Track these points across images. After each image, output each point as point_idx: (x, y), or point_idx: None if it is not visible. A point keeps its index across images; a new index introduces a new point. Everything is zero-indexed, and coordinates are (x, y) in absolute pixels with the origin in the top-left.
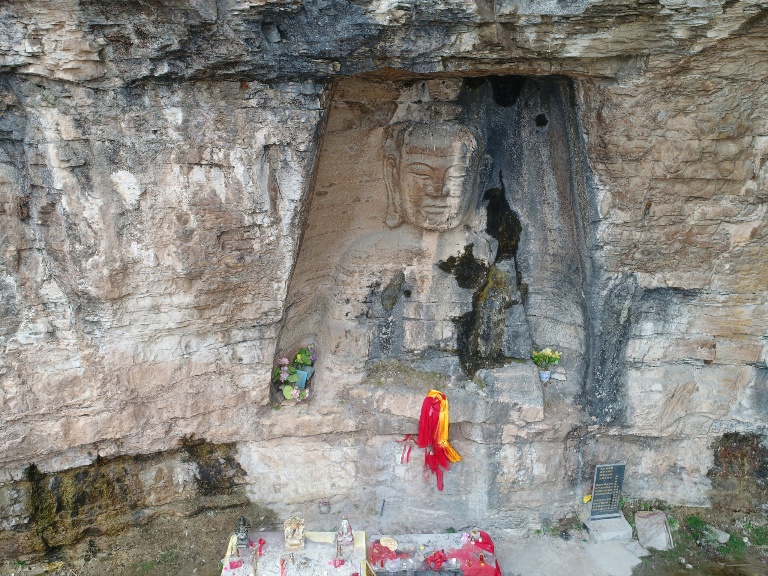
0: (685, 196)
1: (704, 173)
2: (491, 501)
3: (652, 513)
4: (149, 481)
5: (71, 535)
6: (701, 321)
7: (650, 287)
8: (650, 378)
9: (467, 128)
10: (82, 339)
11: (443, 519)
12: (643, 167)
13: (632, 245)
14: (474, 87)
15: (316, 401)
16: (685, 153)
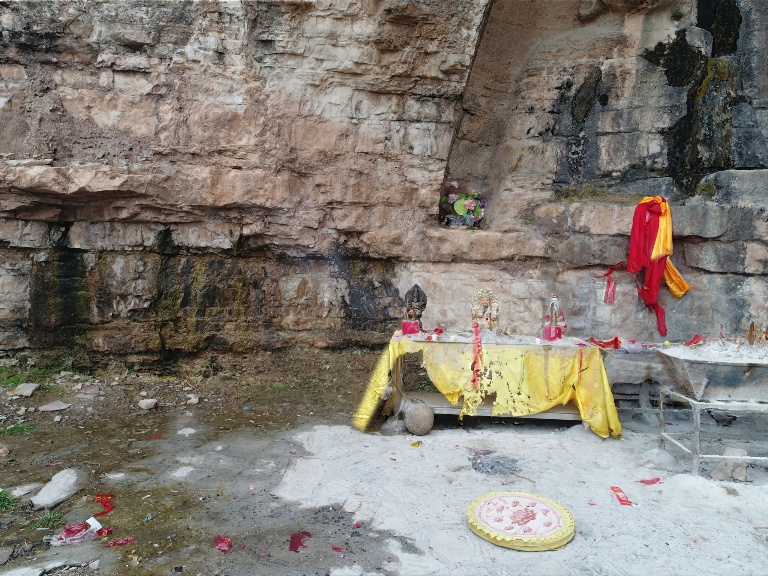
0: None
1: None
2: None
3: None
4: (290, 293)
5: (193, 338)
6: None
7: None
8: None
9: None
10: (250, 68)
11: (670, 375)
12: None
13: None
14: None
15: None
16: None
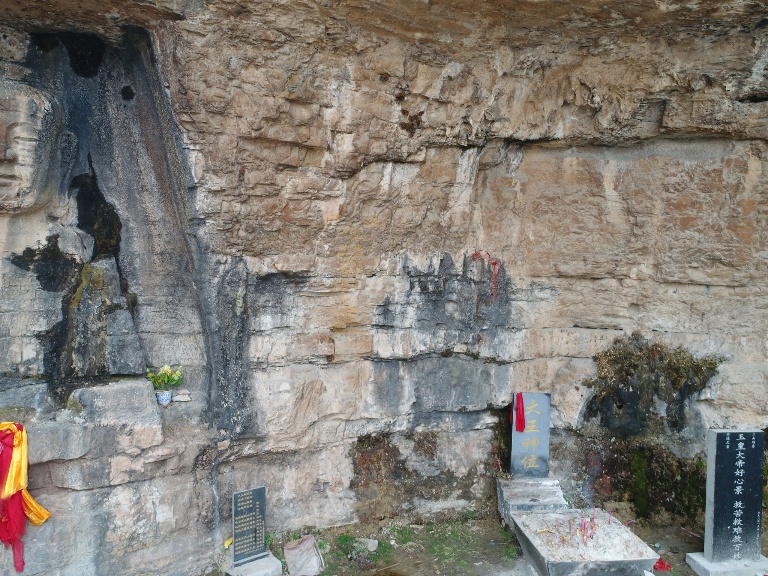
0: (274, 163)
1: (285, 136)
2: (100, 571)
3: (301, 540)
4: None
5: None
6: (316, 314)
7: (261, 273)
8: (277, 379)
9: (38, 90)
10: None
11: None
12: (228, 123)
13: (234, 219)
14: (46, 49)
15: None
16: (263, 109)
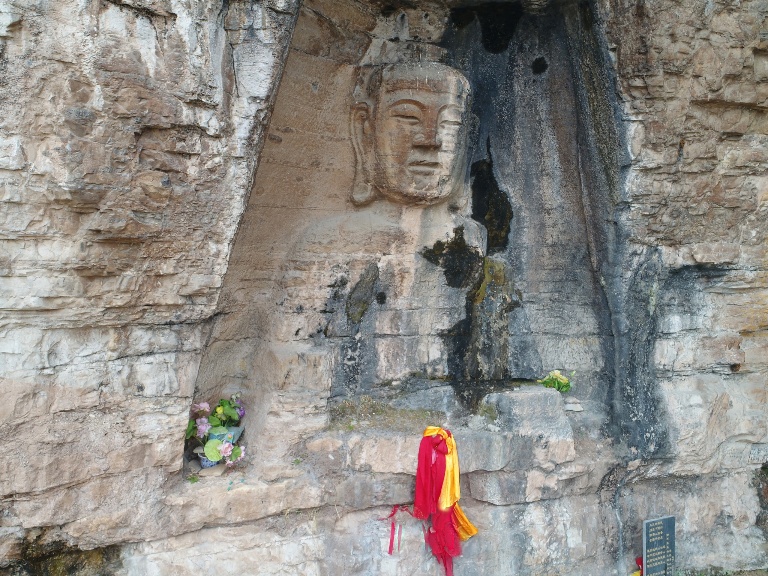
0: (719, 132)
1: (742, 97)
2: None
3: None
4: None
5: None
6: (725, 314)
7: (676, 266)
8: (684, 391)
9: None
10: None
11: None
12: (681, 86)
13: (662, 201)
14: (461, 26)
15: (255, 465)
16: (727, 64)
